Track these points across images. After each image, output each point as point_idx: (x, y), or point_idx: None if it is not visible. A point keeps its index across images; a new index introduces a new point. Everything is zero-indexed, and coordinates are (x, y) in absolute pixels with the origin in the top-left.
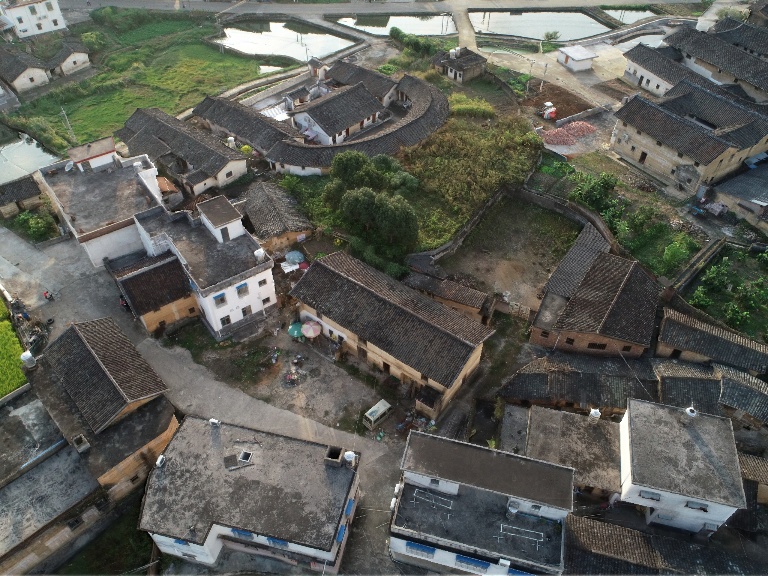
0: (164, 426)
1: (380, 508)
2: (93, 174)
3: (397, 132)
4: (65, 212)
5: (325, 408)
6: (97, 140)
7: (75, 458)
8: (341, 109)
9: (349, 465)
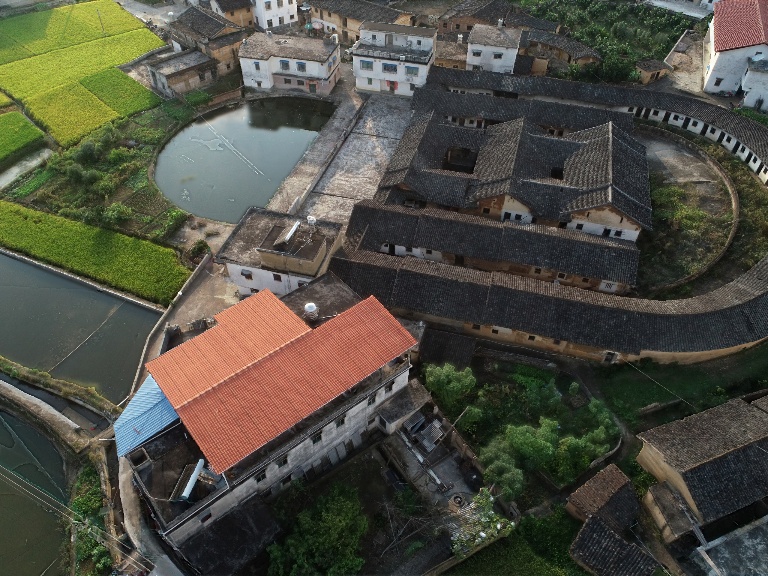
0: None
1: (351, 80)
2: None
3: None
4: None
5: None
6: None
7: (199, 54)
8: None
9: (335, 41)
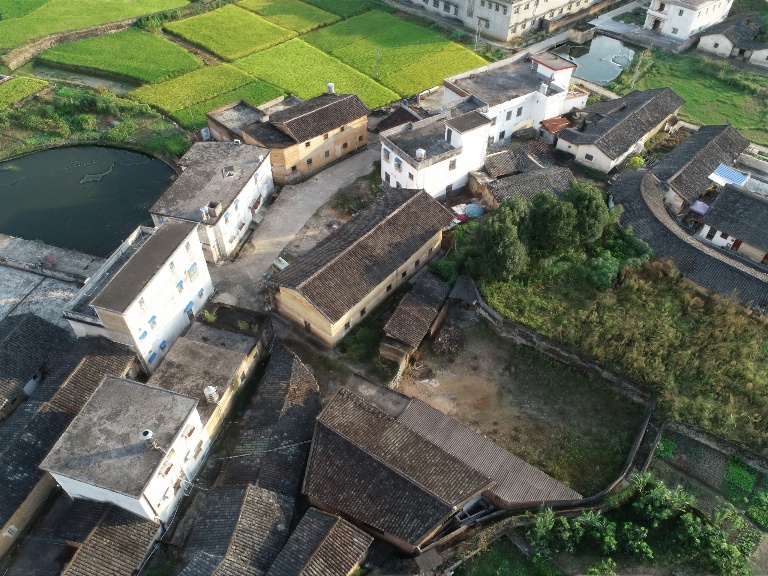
0: (270, 146)
1: None
2: (535, 76)
3: (707, 258)
4: (480, 73)
5: (302, 245)
6: (567, 60)
7: None
8: (763, 220)
9: None
